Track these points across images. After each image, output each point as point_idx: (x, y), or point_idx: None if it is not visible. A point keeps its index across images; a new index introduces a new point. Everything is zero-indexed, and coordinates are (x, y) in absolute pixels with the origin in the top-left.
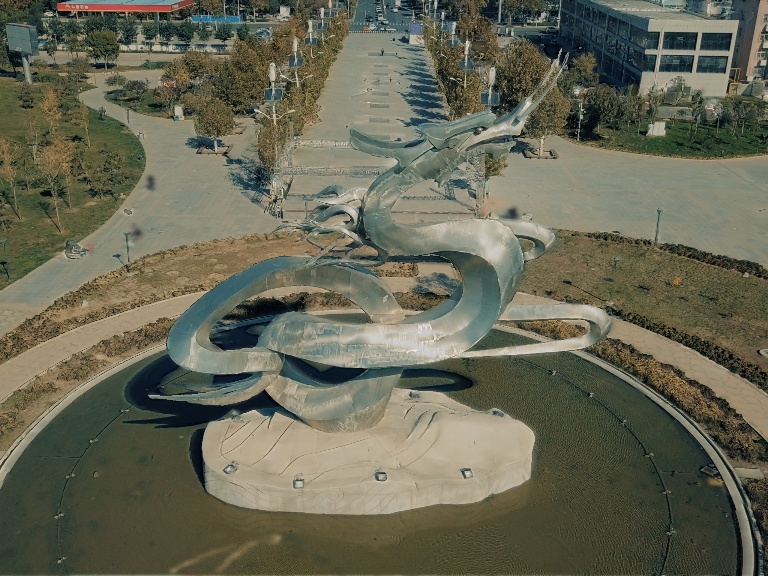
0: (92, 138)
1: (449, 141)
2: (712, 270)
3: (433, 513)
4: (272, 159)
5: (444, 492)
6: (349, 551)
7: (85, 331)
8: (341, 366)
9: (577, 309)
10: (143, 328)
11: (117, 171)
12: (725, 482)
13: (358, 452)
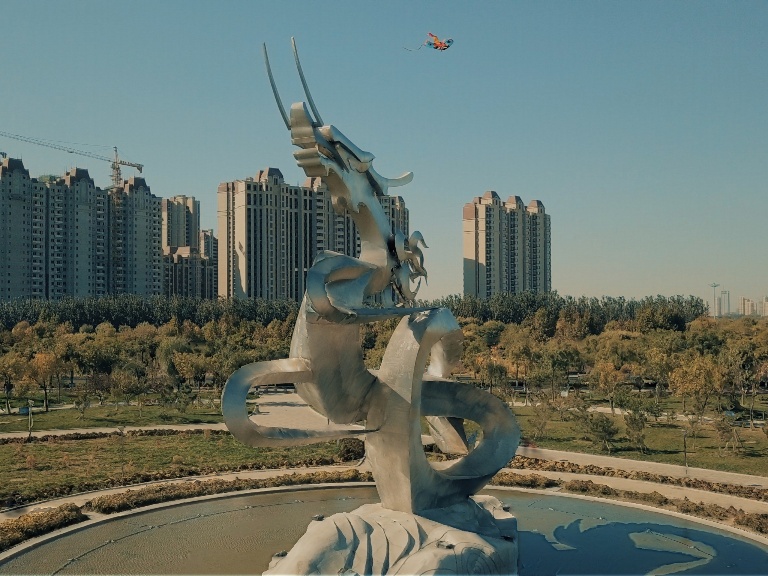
0: None
1: None
2: None
3: None
4: None
5: None
6: None
7: None
8: None
9: None
10: None
11: None
12: None
13: None
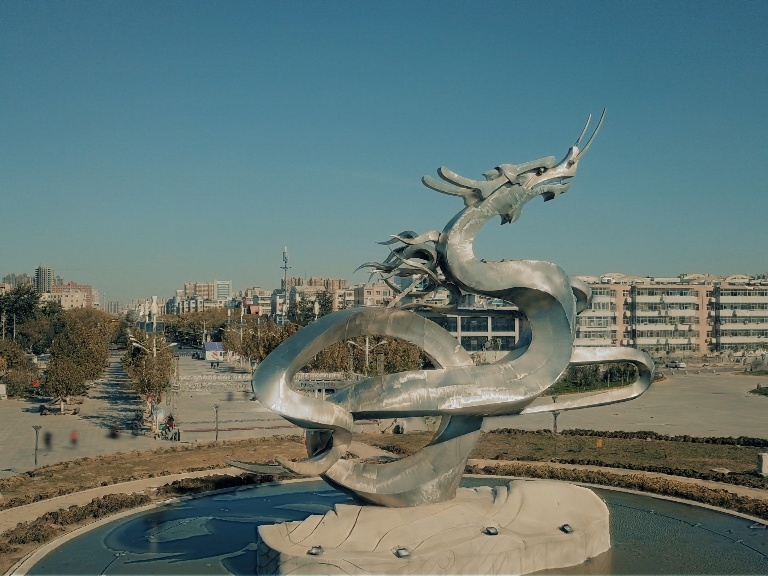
0: None
1: (519, 178)
2: (618, 440)
3: None
4: (159, 387)
5: (548, 553)
6: None
7: (15, 512)
8: (434, 409)
9: (629, 351)
10: (94, 499)
11: None
12: None
13: (452, 517)
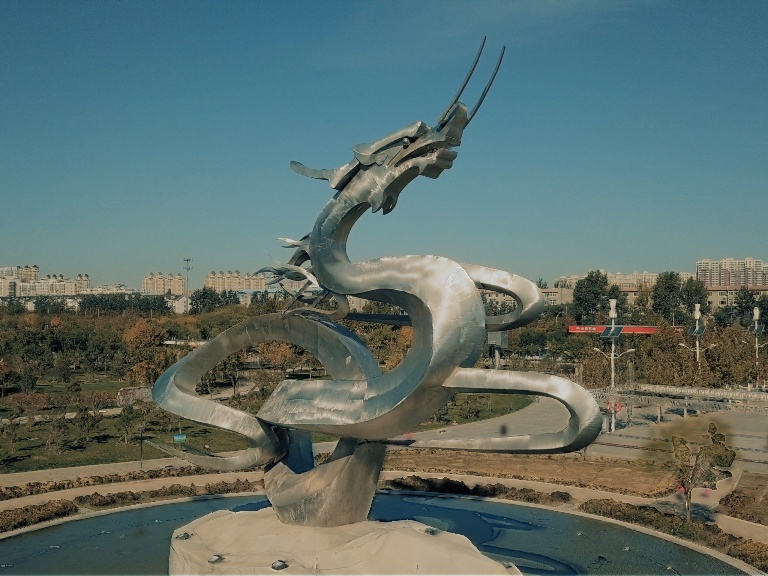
0: (492, 398)
1: (376, 156)
2: None
3: None
4: None
5: None
6: None
7: None
8: (276, 422)
9: (541, 379)
10: None
11: (465, 406)
12: None
13: (286, 542)
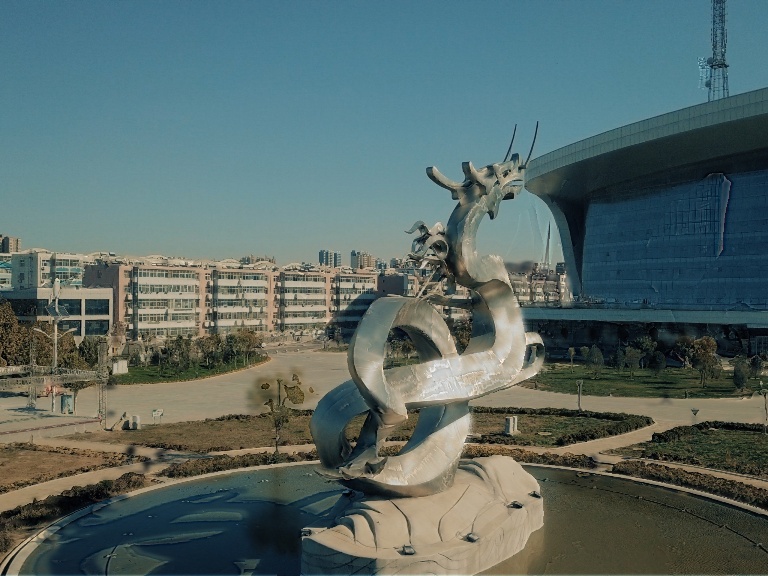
0: None
1: None
2: None
3: (530, 545)
4: None
5: (533, 518)
6: (557, 574)
7: None
8: (466, 396)
9: (537, 336)
10: None
11: None
12: (603, 474)
13: (476, 498)
